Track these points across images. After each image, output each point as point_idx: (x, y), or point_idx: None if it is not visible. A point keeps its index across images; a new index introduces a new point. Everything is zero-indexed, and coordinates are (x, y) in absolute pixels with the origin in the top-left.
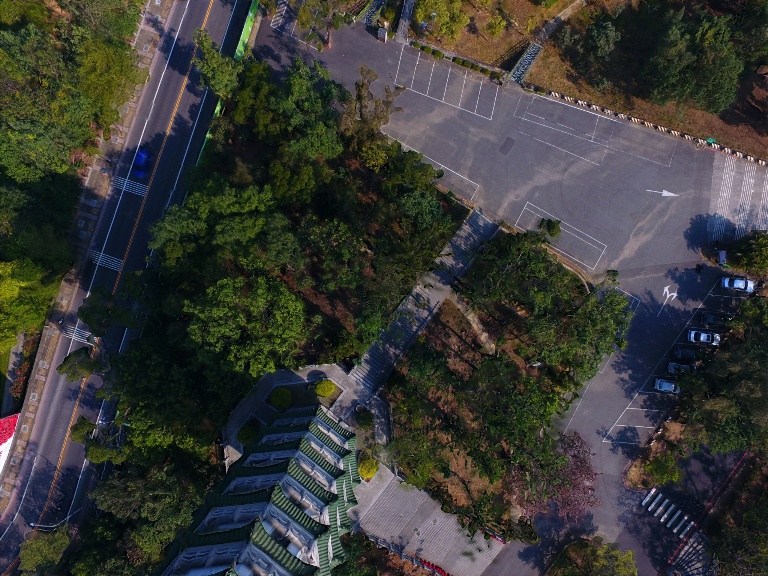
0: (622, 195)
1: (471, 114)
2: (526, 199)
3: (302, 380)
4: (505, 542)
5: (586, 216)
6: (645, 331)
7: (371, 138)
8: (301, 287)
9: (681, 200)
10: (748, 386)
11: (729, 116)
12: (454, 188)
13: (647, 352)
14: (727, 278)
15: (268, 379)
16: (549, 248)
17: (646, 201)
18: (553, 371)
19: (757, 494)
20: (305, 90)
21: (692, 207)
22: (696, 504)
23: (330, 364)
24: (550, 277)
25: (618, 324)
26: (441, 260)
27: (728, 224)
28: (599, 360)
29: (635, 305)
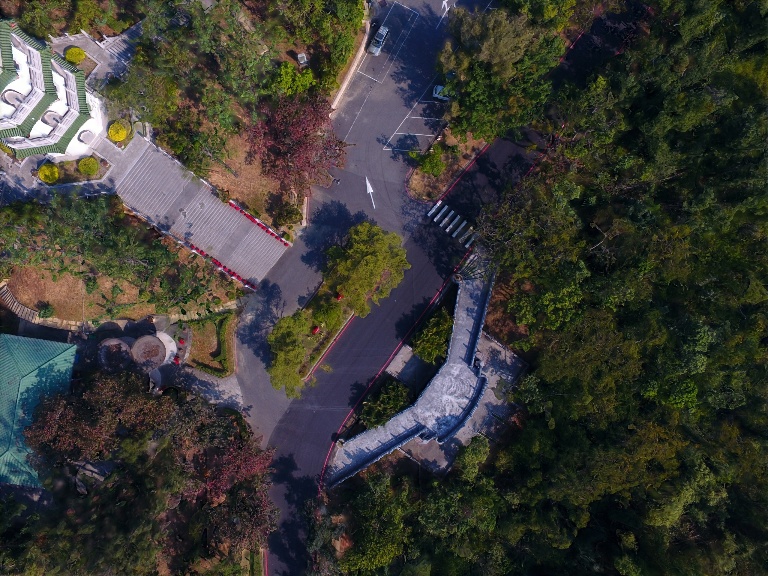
0: None
1: None
2: None
3: (58, 55)
4: (281, 237)
5: None
6: (424, 43)
7: None
8: None
9: None
10: (468, 22)
11: None
12: None
13: (426, 63)
14: None
15: None
16: None
17: None
18: None
19: None
20: None
21: None
22: None
23: (82, 35)
24: None
25: None
26: None
27: None
28: (346, 30)
29: (414, 18)
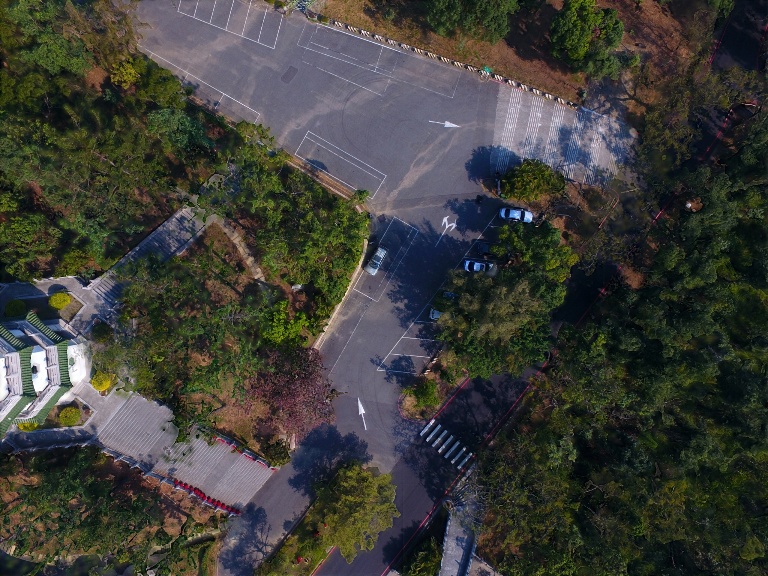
0: (404, 125)
1: (254, 43)
2: (307, 128)
3: (43, 294)
4: (268, 466)
5: (367, 146)
6: (422, 261)
7: (114, 52)
8: (52, 204)
9: (463, 131)
10: (467, 298)
11: (524, 52)
12: (235, 116)
13: (424, 282)
14: (504, 208)
15: (9, 293)
16: (328, 177)
17: (428, 132)
18: (316, 295)
19: (537, 427)
20: (42, 2)
21: (475, 139)
22: (475, 436)
23: None
24: (290, 193)
25: (351, 239)
26: (211, 185)
27: (513, 157)
28: (342, 278)
29: (413, 235)
